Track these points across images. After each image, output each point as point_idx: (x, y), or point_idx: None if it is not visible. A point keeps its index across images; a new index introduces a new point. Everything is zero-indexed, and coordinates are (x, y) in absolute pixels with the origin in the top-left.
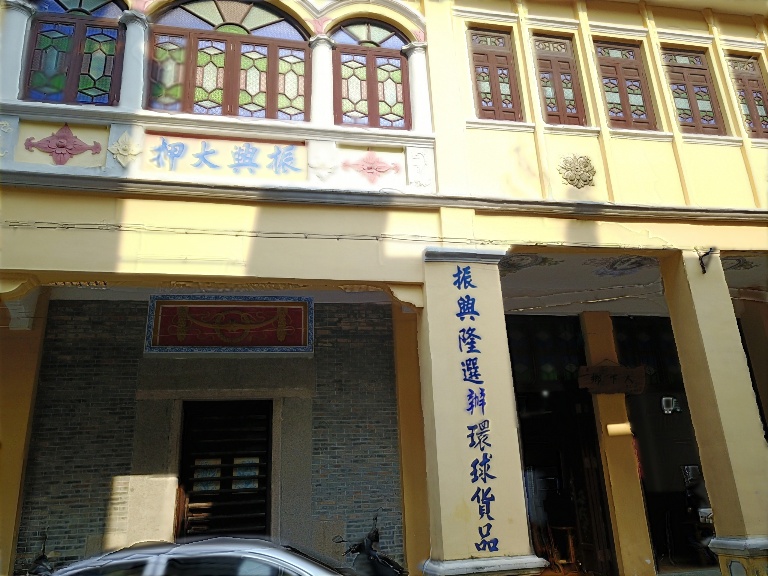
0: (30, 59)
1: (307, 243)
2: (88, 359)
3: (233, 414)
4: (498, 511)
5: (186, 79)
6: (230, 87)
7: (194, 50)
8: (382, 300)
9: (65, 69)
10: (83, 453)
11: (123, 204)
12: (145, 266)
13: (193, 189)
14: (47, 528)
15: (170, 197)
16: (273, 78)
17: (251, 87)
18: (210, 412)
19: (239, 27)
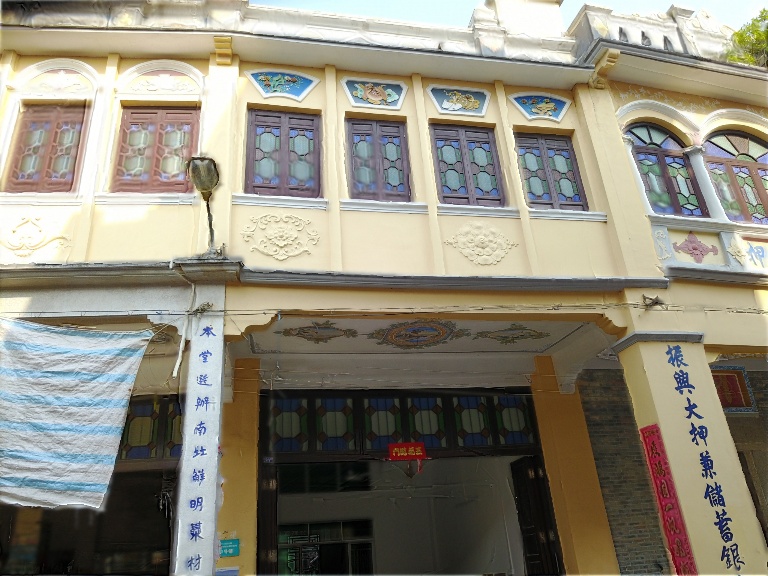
0: None
1: None
2: (611, 419)
3: None
4: None
5: (739, 197)
6: (767, 203)
7: None
8: None
9: (665, 189)
10: (633, 499)
11: (757, 294)
12: None
13: None
14: (631, 563)
15: None
16: None
17: None
18: None
19: (748, 156)
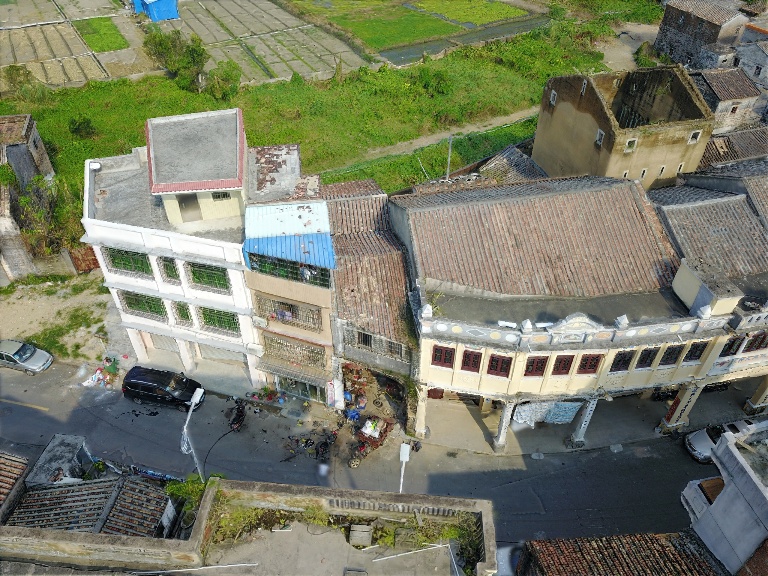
0: (723, 348)
1: None
2: None
3: None
4: (767, 398)
5: None
6: None
7: None
8: None
9: (729, 348)
10: None
11: None
12: None
13: None
14: None
15: None
16: None
17: None
18: None
19: None
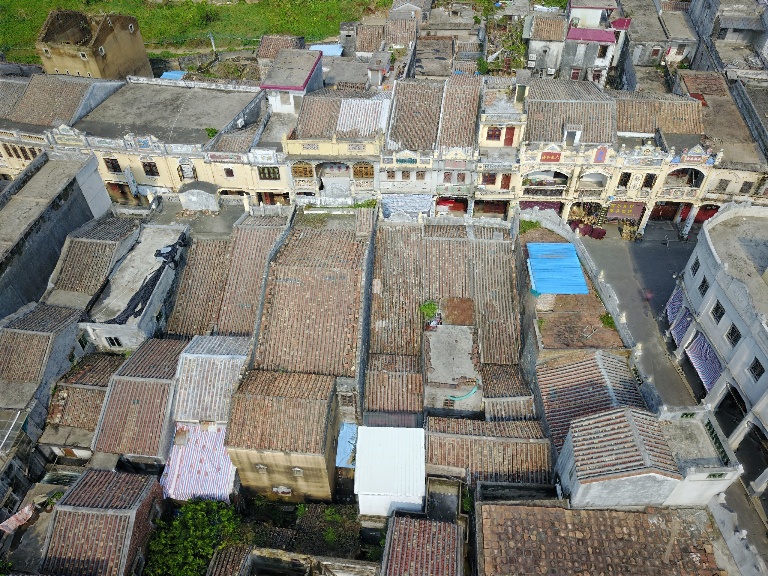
0: None
1: None
2: None
3: None
4: None
5: None
6: None
7: None
8: None
9: None
10: None
11: None
12: None
13: None
14: None
15: None
16: None
17: None
18: None
19: None
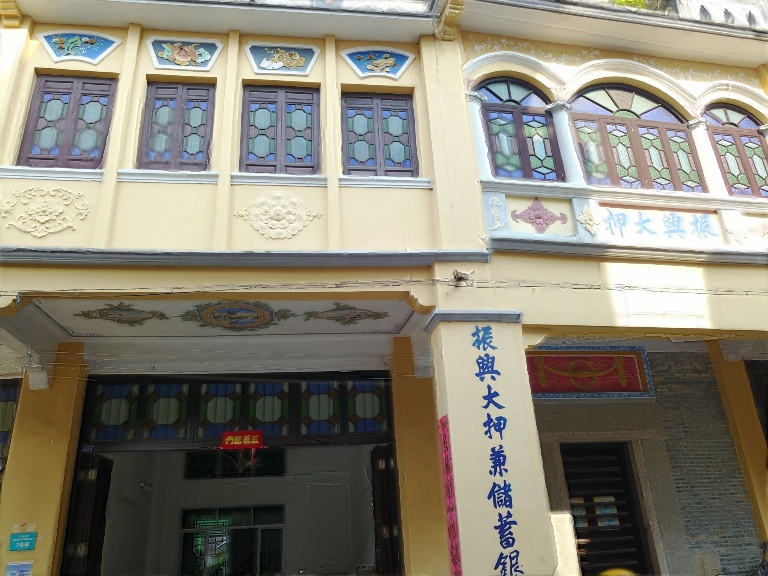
0: (489, 143)
1: (749, 299)
2: None
3: (592, 455)
4: None
5: (608, 158)
6: (642, 164)
7: (606, 133)
8: (700, 349)
9: (517, 151)
10: None
11: (604, 267)
12: (636, 321)
13: (659, 254)
14: None
15: (640, 261)
16: (671, 156)
17: (656, 164)
18: (573, 453)
19: (630, 113)
